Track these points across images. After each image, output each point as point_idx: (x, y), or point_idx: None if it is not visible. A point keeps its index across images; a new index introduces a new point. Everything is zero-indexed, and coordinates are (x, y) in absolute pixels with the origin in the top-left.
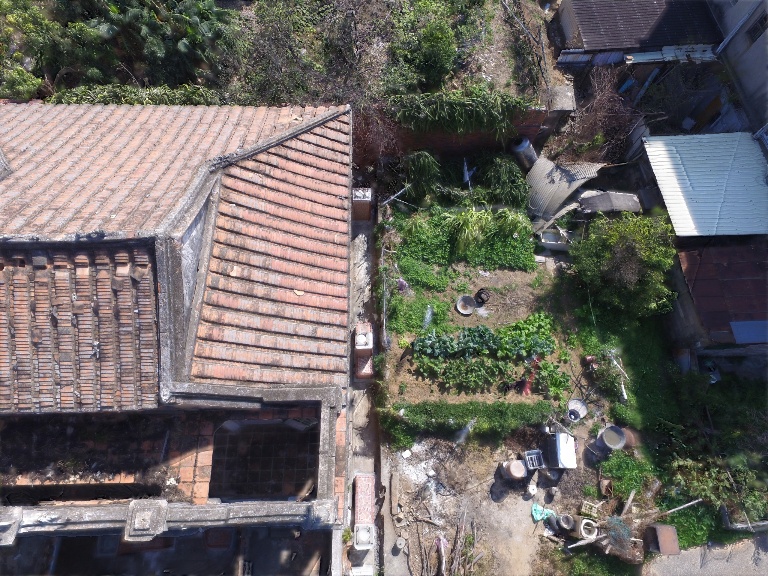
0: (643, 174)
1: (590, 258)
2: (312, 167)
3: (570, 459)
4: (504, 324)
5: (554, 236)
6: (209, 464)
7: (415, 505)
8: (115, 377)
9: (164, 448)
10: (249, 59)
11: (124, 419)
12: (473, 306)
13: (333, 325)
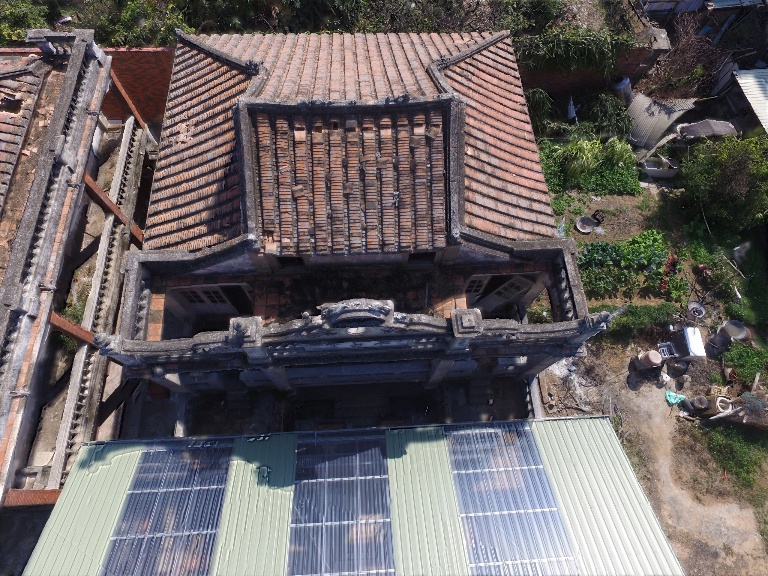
0: (731, 107)
1: (701, 174)
2: (495, 78)
3: (699, 348)
4: (621, 240)
5: (654, 165)
6: (465, 308)
7: (562, 395)
8: (411, 222)
9: (427, 296)
10: (364, 13)
11: (388, 275)
12: (592, 225)
13: (541, 202)
